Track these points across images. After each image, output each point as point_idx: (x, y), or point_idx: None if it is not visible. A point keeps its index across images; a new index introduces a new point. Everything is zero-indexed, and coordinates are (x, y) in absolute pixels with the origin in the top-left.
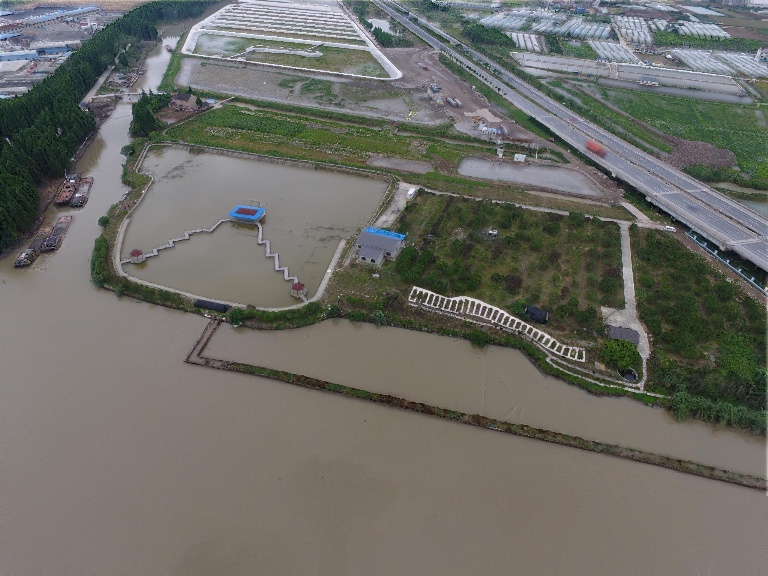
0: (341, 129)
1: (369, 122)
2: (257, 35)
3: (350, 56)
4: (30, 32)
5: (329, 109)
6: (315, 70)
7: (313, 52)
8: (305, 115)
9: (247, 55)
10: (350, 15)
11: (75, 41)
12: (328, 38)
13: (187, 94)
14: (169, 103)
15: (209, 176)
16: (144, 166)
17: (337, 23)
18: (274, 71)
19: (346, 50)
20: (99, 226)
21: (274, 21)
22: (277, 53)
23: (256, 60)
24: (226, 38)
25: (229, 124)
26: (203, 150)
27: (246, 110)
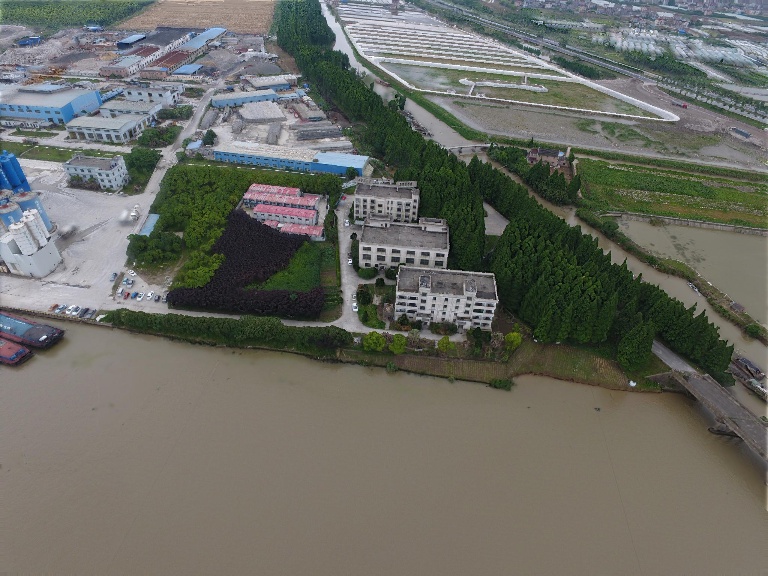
0: (745, 187)
1: (753, 177)
2: (444, 64)
3: (575, 90)
4: (208, 62)
5: (688, 161)
6: (585, 110)
7: (539, 86)
8: (670, 169)
9: (475, 90)
10: (483, 38)
11: (289, 75)
12: (515, 67)
13: (553, 149)
14: (528, 159)
15: (727, 257)
16: (642, 246)
17: (489, 48)
18: (543, 111)
19: (558, 82)
20: (741, 336)
21: (423, 45)
22: (501, 87)
23: (496, 97)
24: (413, 68)
25: (631, 185)
26: (663, 221)
27: (610, 165)
